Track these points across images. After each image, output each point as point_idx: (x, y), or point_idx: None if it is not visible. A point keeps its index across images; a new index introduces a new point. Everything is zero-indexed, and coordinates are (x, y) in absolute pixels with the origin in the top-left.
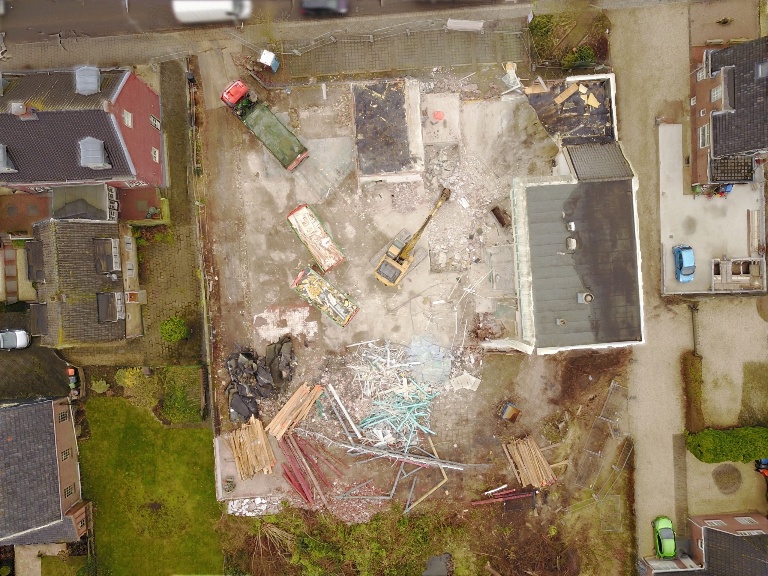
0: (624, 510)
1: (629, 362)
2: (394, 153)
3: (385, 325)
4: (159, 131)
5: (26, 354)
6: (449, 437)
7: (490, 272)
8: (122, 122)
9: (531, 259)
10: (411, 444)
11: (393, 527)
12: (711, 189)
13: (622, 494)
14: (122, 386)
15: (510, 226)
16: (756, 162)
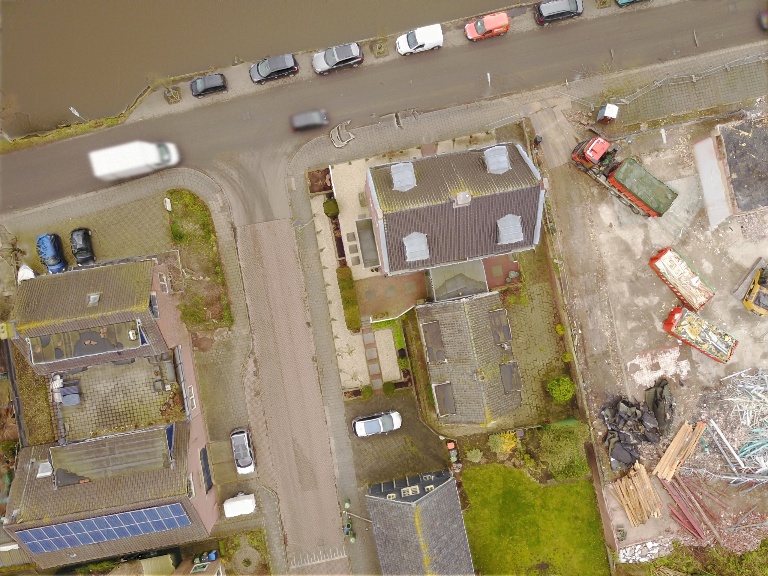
0: None
1: None
2: None
3: (754, 353)
4: None
5: (397, 434)
6: None
7: None
8: None
9: None
10: None
11: None
12: None
13: None
14: (495, 452)
15: None
16: None
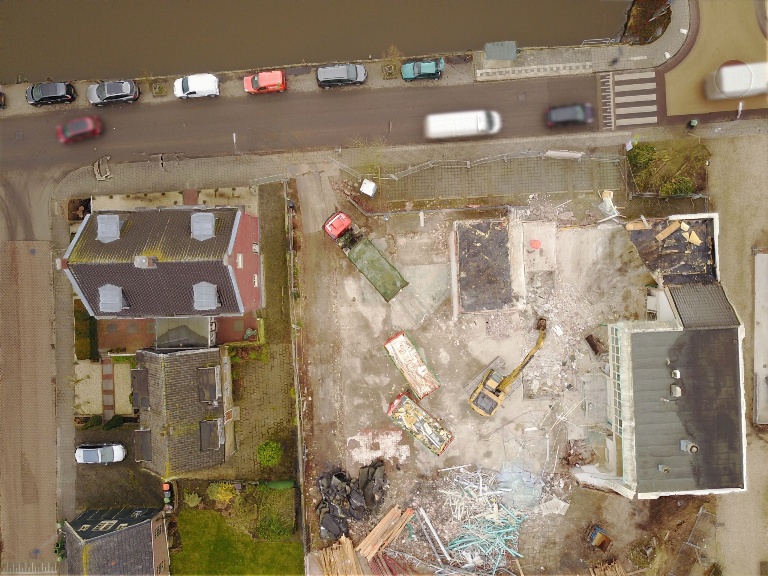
0: None
1: None
2: (496, 291)
3: (477, 450)
4: (257, 253)
5: (121, 466)
6: (536, 560)
7: (583, 400)
8: (236, 268)
9: (634, 405)
10: (499, 566)
11: None
12: None
13: None
14: (214, 499)
15: (603, 353)
16: None
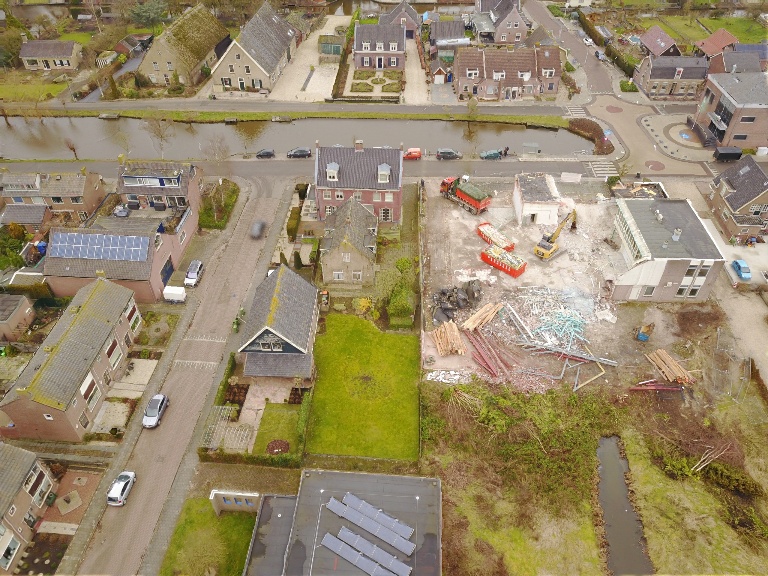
0: (764, 406)
1: (726, 319)
2: (543, 195)
3: (543, 280)
4: None
5: None
6: (601, 348)
7: (610, 262)
8: None
9: (637, 224)
10: (572, 348)
11: (565, 402)
12: (743, 243)
13: (757, 395)
14: (355, 308)
15: (617, 249)
16: (766, 234)
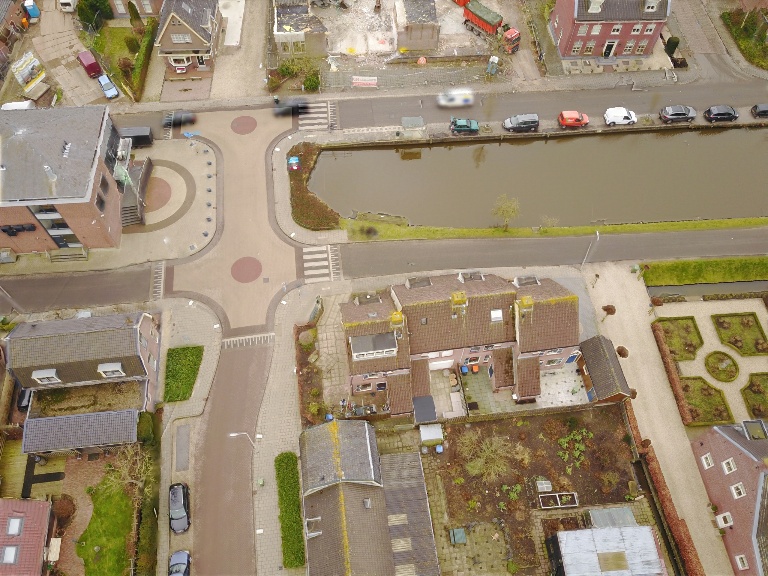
0: None
1: None
2: None
3: None
4: None
5: None
6: None
7: None
8: None
9: None
10: None
11: None
12: None
13: None
14: None
15: None
16: None
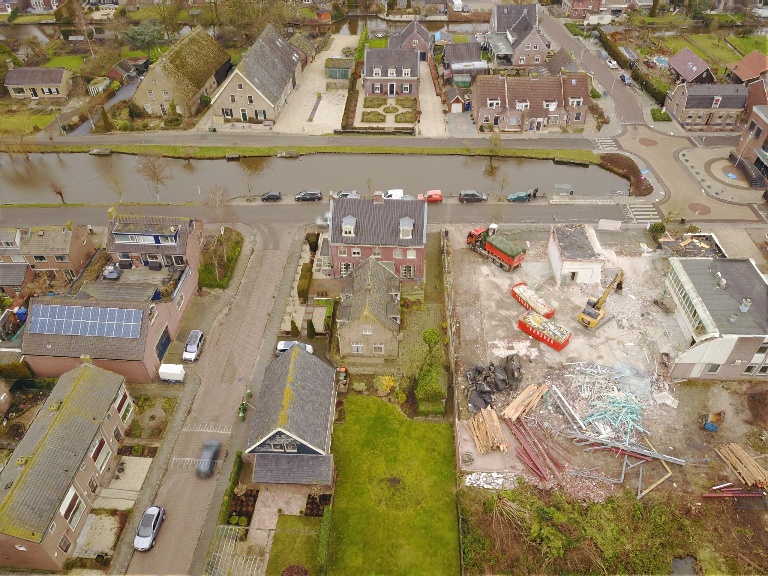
0: None
1: None
2: (584, 251)
3: (591, 354)
4: None
5: None
6: (663, 440)
7: (664, 331)
8: None
9: (696, 290)
10: (630, 441)
11: (629, 514)
12: None
13: None
14: (377, 388)
15: (669, 313)
16: None
